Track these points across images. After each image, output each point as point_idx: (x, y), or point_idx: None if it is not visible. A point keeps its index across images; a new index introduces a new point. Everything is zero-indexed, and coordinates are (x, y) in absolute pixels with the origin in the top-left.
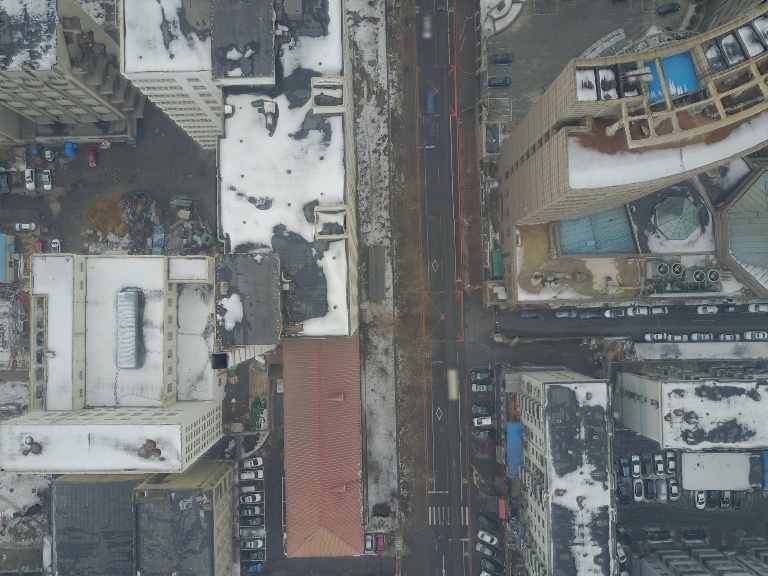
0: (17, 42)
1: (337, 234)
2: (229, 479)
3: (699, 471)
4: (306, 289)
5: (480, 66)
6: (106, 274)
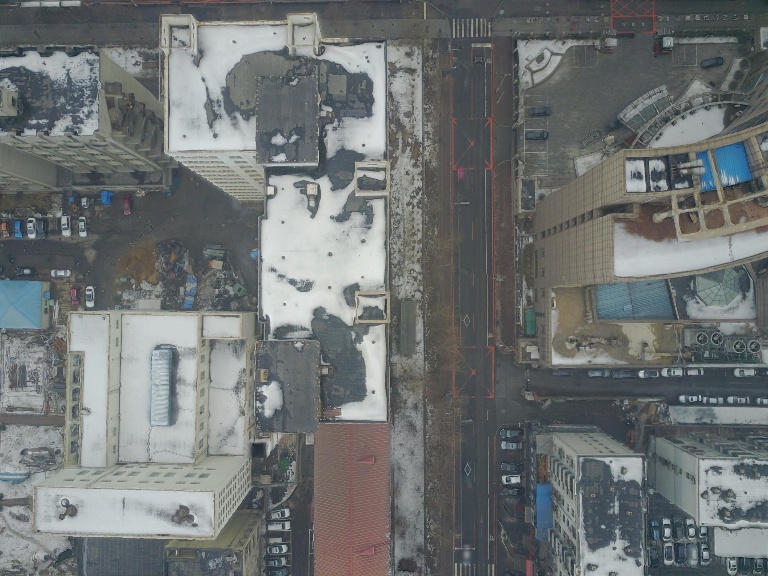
0: (59, 106)
1: (377, 318)
2: (257, 532)
3: (732, 538)
4: (345, 373)
5: (517, 120)
6: (141, 330)
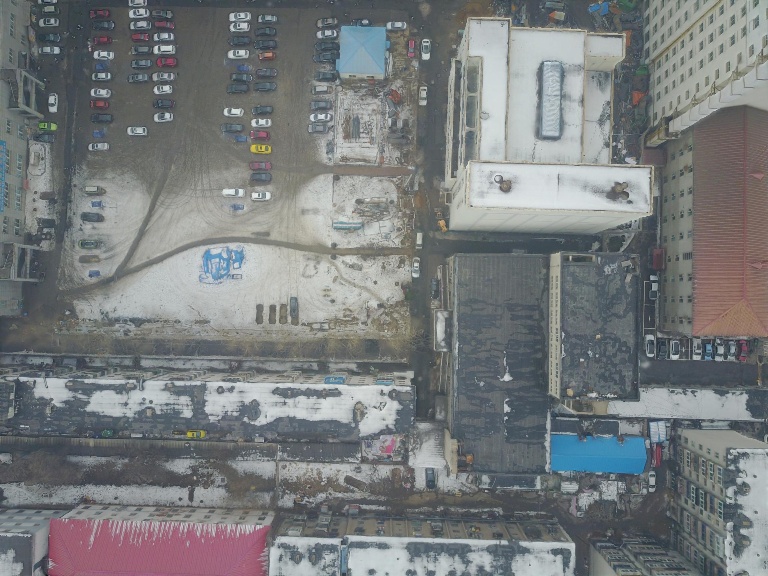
0: None
1: None
2: None
3: None
4: None
5: None
6: (526, 47)
